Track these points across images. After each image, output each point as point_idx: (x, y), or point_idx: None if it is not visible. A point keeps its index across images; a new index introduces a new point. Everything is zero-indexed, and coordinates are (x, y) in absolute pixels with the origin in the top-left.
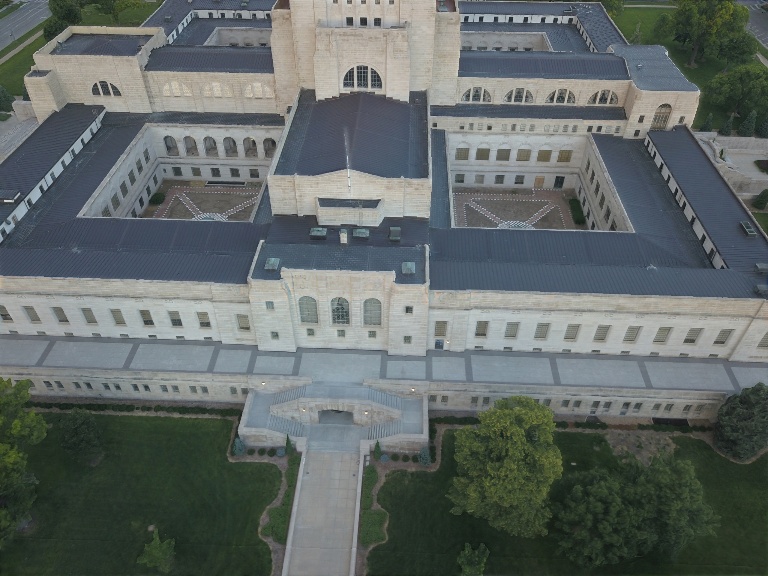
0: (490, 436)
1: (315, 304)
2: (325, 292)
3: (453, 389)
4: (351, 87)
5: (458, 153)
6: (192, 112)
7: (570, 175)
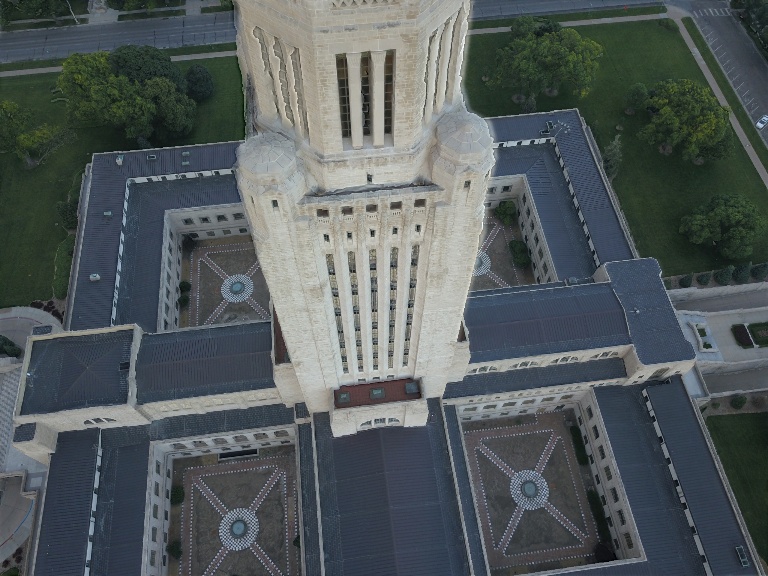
0: None
1: None
2: None
3: None
4: (368, 425)
5: (466, 408)
6: (193, 414)
7: (570, 404)
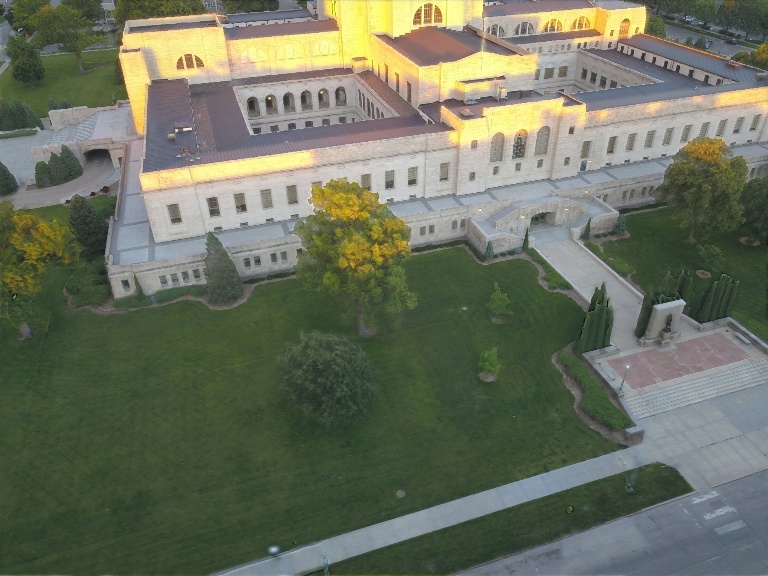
0: (697, 158)
1: (502, 141)
2: (513, 125)
3: (612, 186)
4: (418, 24)
5: None
6: (266, 76)
7: (568, 87)
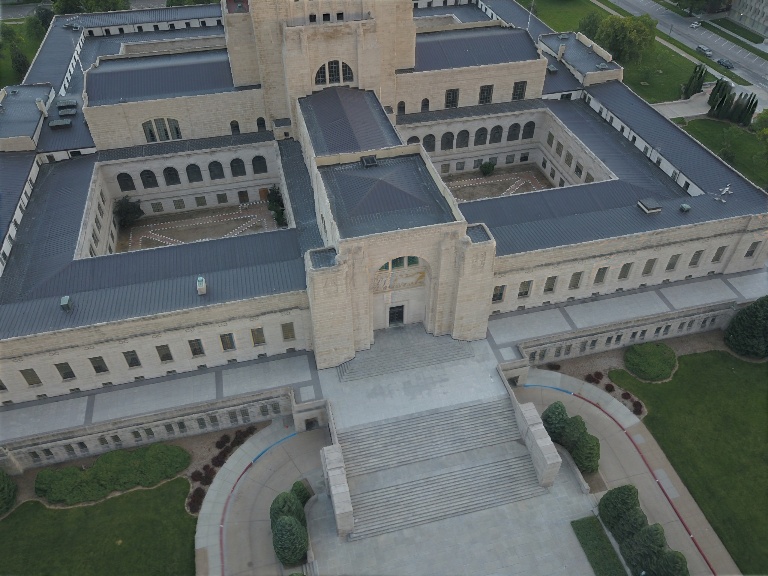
0: (630, 27)
1: None
2: None
3: None
4: None
5: None
6: None
7: None
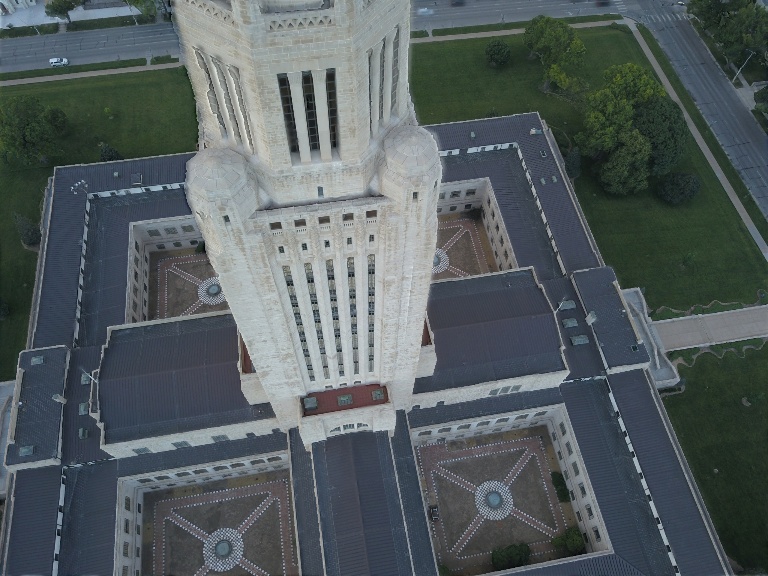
0: None
1: None
2: None
3: None
4: None
5: None
6: None
7: None
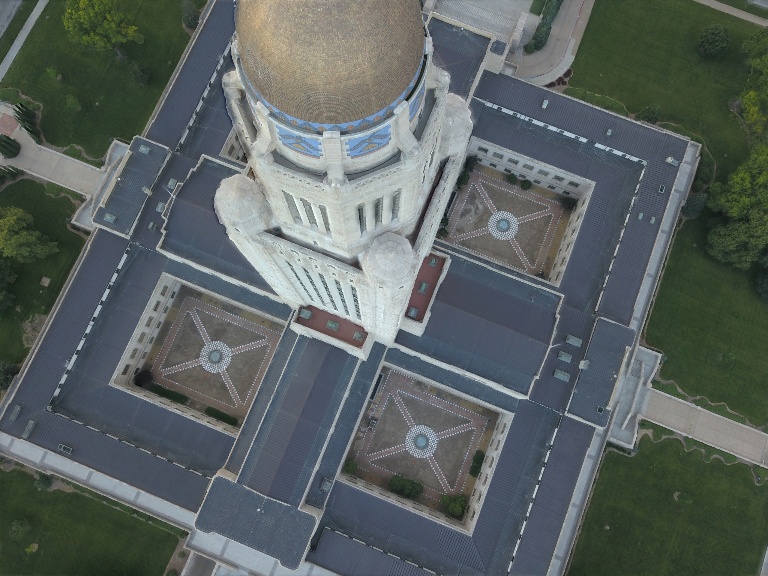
0: None
1: None
2: None
3: None
4: None
5: None
6: None
7: None
